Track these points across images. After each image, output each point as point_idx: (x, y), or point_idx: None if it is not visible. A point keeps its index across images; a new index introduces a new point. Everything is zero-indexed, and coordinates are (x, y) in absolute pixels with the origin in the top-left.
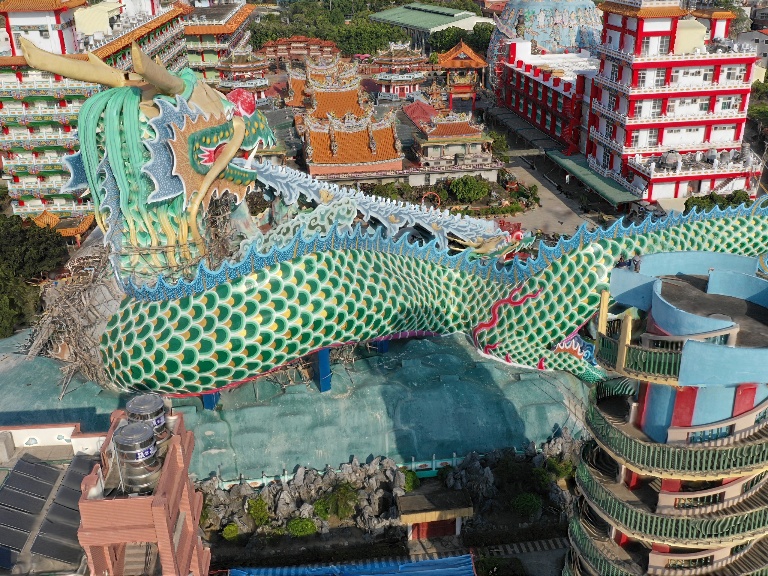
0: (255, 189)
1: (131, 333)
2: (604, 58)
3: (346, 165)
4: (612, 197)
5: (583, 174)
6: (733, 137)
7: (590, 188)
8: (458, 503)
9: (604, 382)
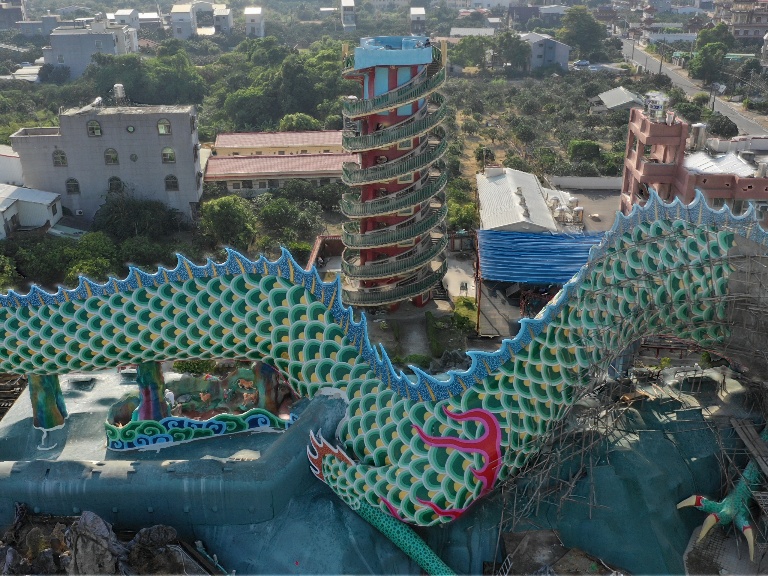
0: None
1: None
2: None
3: None
4: None
5: None
6: None
7: None
8: (477, 345)
9: (428, 116)
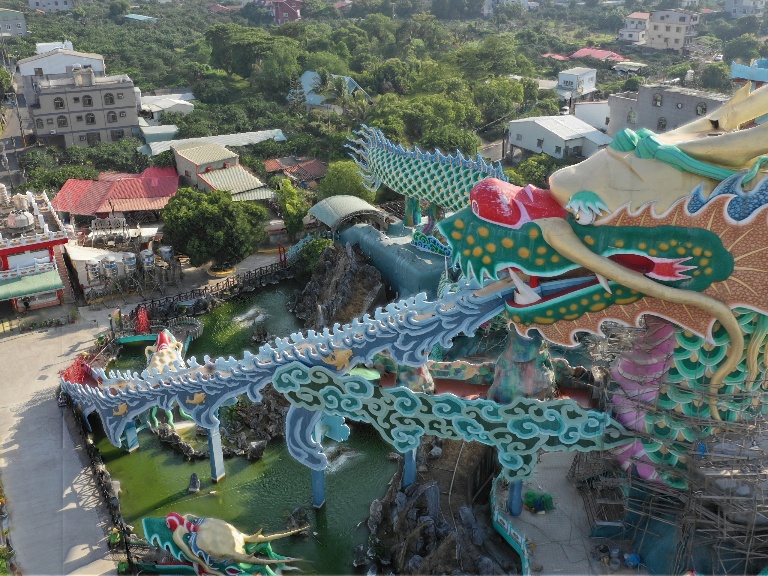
0: (448, 345)
1: None
2: None
3: None
4: (42, 286)
5: None
6: None
7: None
8: None
9: None
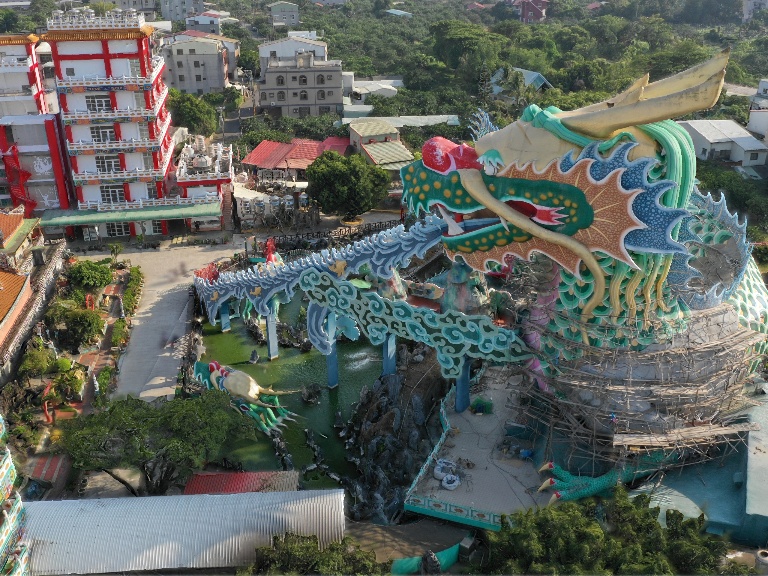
0: (407, 263)
1: (762, 312)
2: (82, 91)
3: (8, 316)
4: (205, 212)
5: (121, 216)
6: (167, 138)
7: (97, 235)
8: None
9: None
